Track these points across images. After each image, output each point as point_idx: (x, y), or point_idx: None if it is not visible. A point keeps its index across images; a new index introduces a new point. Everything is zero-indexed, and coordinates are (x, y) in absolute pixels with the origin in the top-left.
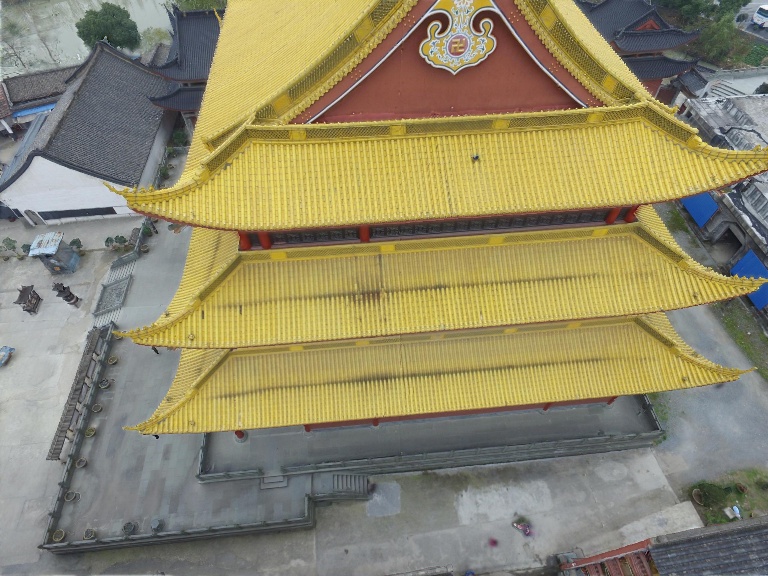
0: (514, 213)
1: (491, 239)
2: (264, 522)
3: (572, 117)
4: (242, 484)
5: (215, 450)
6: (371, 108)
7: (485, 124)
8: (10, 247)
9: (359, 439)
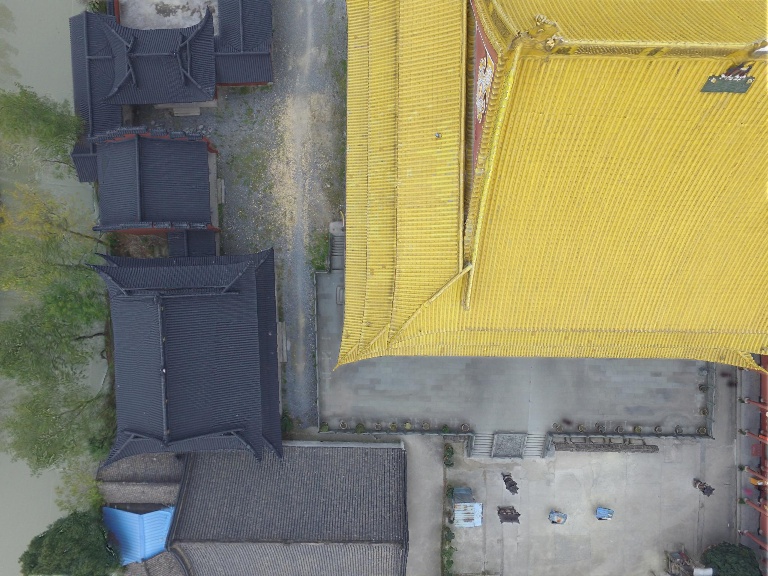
0: None
1: None
2: None
3: None
4: None
5: None
6: None
7: None
8: (452, 551)
9: None
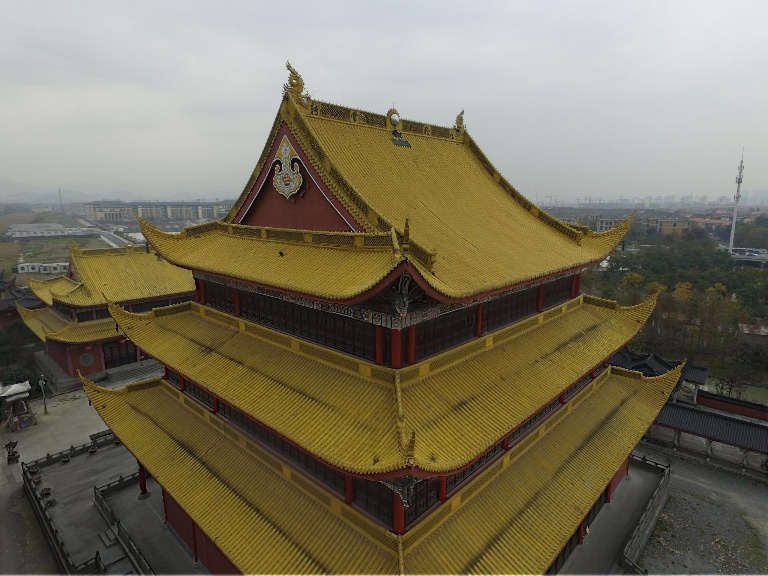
0: (260, 284)
1: (292, 342)
2: (63, 544)
3: (346, 239)
4: (101, 523)
5: (126, 491)
6: (264, 222)
7: (301, 237)
8: None
9: (176, 561)
